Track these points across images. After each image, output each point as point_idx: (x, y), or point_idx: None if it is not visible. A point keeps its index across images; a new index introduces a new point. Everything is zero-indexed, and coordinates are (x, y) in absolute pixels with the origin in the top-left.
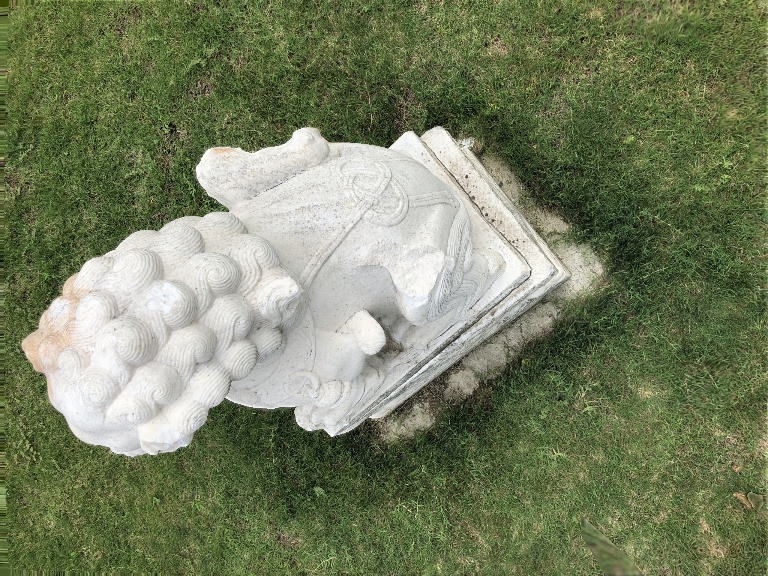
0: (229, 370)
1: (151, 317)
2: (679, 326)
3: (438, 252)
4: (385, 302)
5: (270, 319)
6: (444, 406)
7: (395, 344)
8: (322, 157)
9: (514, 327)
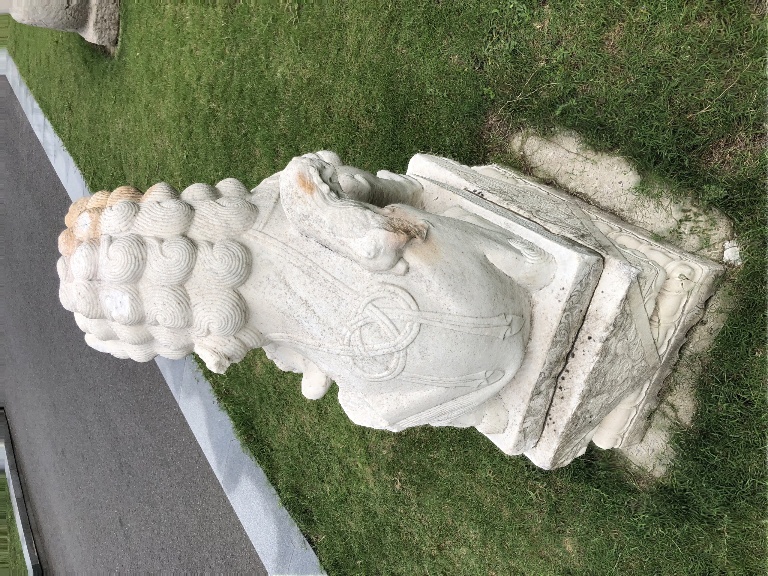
0: (157, 353)
1: (104, 307)
2: (638, 570)
3: (385, 420)
4: None
5: None
6: None
7: None
8: (377, 270)
9: None
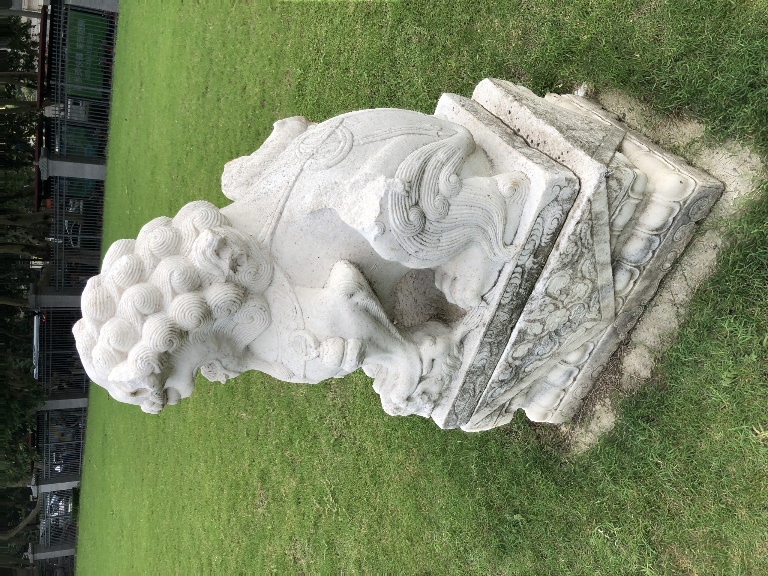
0: (173, 318)
1: (107, 282)
2: None
3: (379, 177)
4: (367, 249)
5: (210, 272)
6: (624, 398)
7: (461, 310)
8: (297, 136)
9: (676, 277)
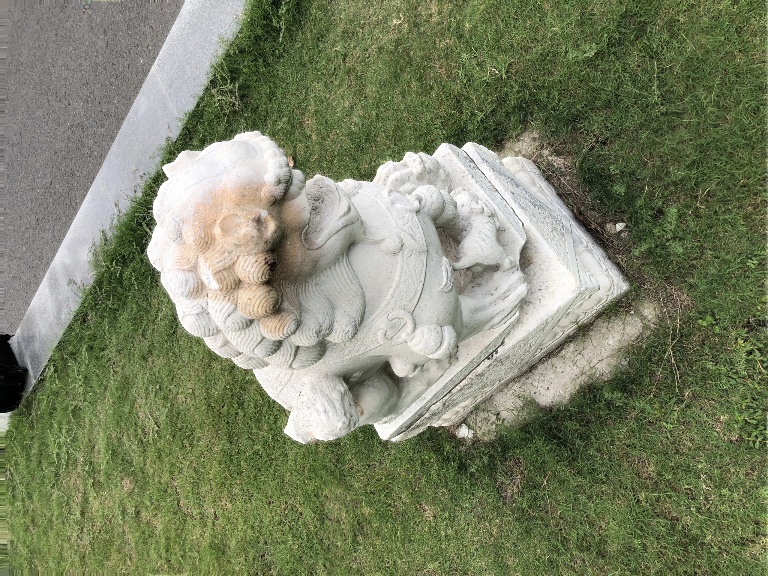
0: None
1: None
2: None
3: None
4: None
5: None
6: None
7: None
8: None
9: None
